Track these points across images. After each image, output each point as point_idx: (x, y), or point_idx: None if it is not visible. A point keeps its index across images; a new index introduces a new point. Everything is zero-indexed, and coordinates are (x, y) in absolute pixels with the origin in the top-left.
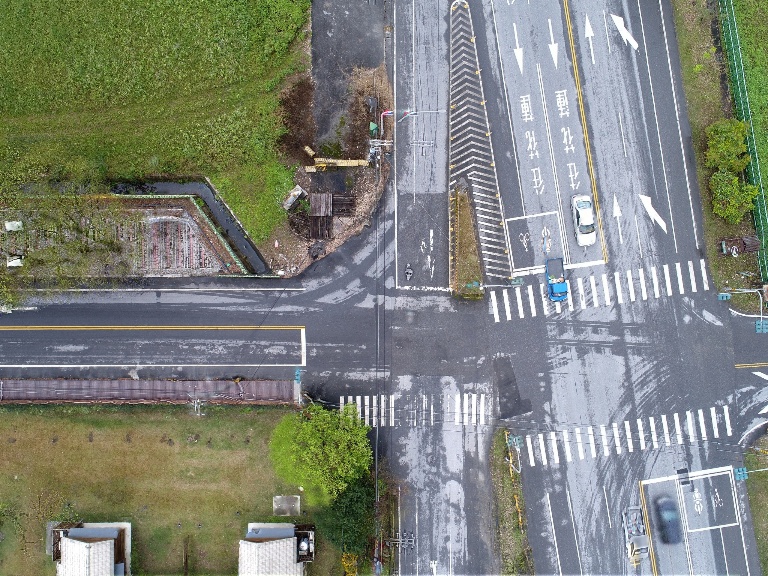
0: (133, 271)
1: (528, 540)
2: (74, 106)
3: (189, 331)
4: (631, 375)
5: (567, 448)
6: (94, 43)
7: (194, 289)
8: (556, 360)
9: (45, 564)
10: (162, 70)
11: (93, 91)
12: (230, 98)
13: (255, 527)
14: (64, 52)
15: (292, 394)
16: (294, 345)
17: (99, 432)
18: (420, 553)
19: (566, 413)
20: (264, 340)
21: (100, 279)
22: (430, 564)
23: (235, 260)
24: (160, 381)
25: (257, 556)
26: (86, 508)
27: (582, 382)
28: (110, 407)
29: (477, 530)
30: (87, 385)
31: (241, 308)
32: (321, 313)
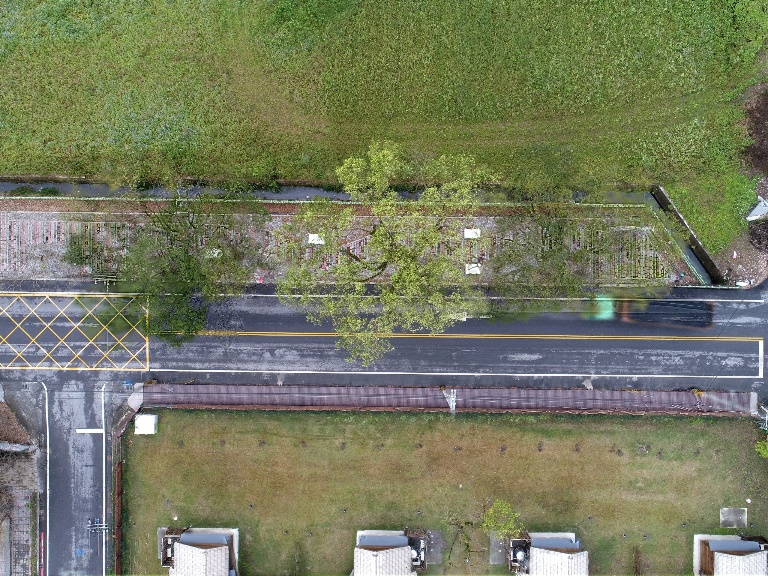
0: (589, 280)
1: None
2: (530, 114)
3: (645, 341)
4: None
5: None
6: (555, 51)
7: (650, 299)
8: None
9: (488, 573)
10: (621, 79)
11: (551, 99)
12: (687, 108)
13: (702, 539)
14: (525, 59)
15: (749, 406)
16: (752, 357)
17: (548, 442)
18: None
19: None
20: (721, 351)
21: (555, 288)
22: None
23: (695, 271)
24: (616, 391)
25: (742, 569)
26: (531, 518)
27: None
28: None
29: None
30: (542, 394)
31: (699, 319)
32: None
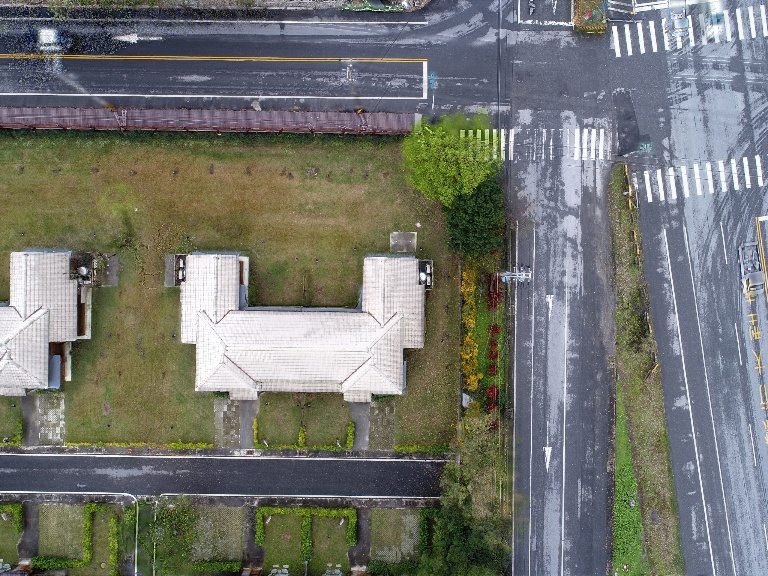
0: (257, 3)
1: (644, 275)
2: None
3: (312, 63)
4: (750, 111)
5: (685, 184)
6: None
7: (317, 22)
8: (676, 96)
9: (163, 296)
10: None
11: None
12: None
13: None
14: None
15: (413, 127)
16: (416, 78)
17: (220, 164)
18: (536, 287)
19: (685, 149)
20: (386, 73)
21: (224, 11)
22: (546, 298)
23: None
24: (282, 112)
25: (383, 269)
26: (205, 241)
27: (701, 118)
28: (231, 141)
29: (593, 266)
30: (210, 115)
31: (364, 41)
32: (443, 46)
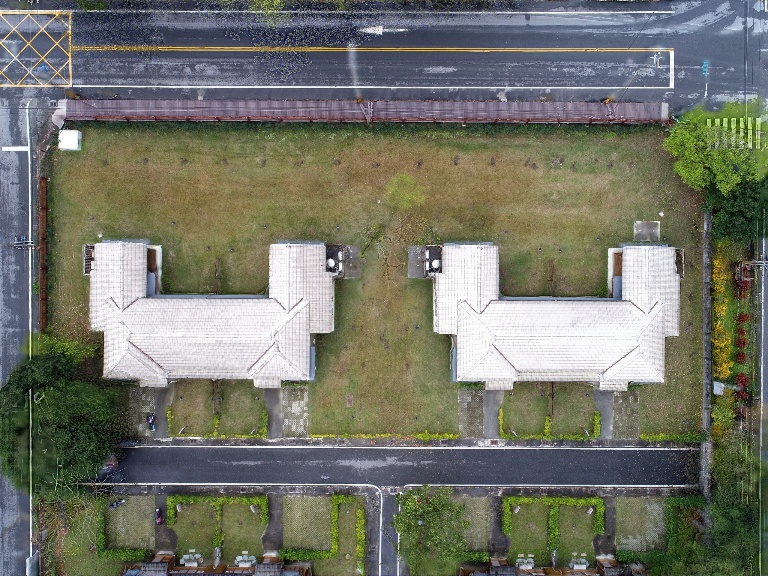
0: None
1: None
2: None
3: (558, 53)
4: None
5: None
6: None
7: (563, 12)
8: None
9: (406, 288)
10: None
11: None
12: None
13: (616, 252)
14: None
15: (660, 116)
16: None
17: (464, 155)
18: None
19: None
20: (633, 62)
21: (469, 2)
22: None
23: None
24: (529, 102)
25: (648, 257)
26: (448, 233)
27: None
28: (474, 132)
29: None
30: (457, 106)
31: (610, 30)
32: (690, 35)
